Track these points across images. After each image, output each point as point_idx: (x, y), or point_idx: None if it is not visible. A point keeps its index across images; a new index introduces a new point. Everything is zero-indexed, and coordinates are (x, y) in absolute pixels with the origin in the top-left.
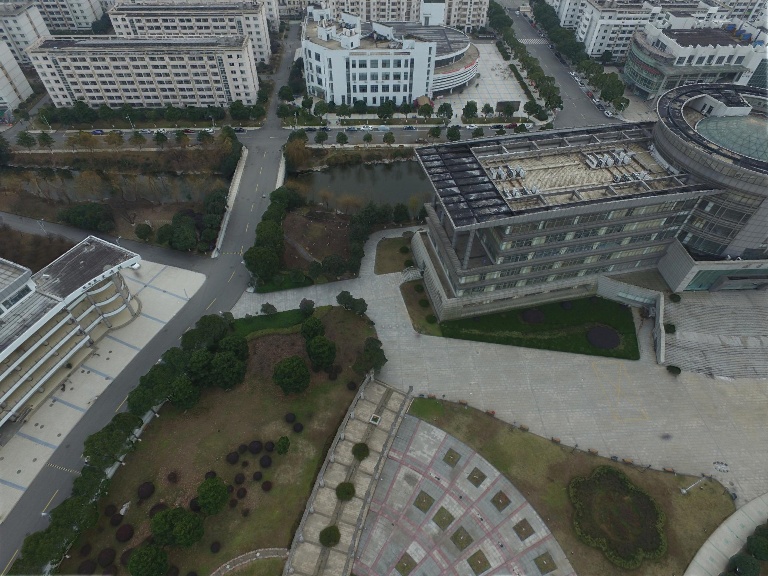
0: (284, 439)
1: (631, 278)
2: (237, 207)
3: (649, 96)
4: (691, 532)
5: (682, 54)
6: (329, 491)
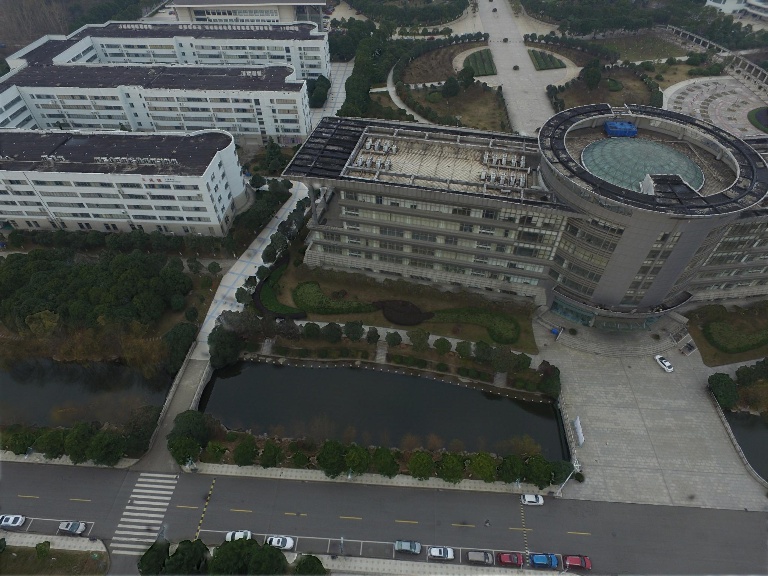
0: None
1: None
2: None
3: None
4: None
5: None
6: None
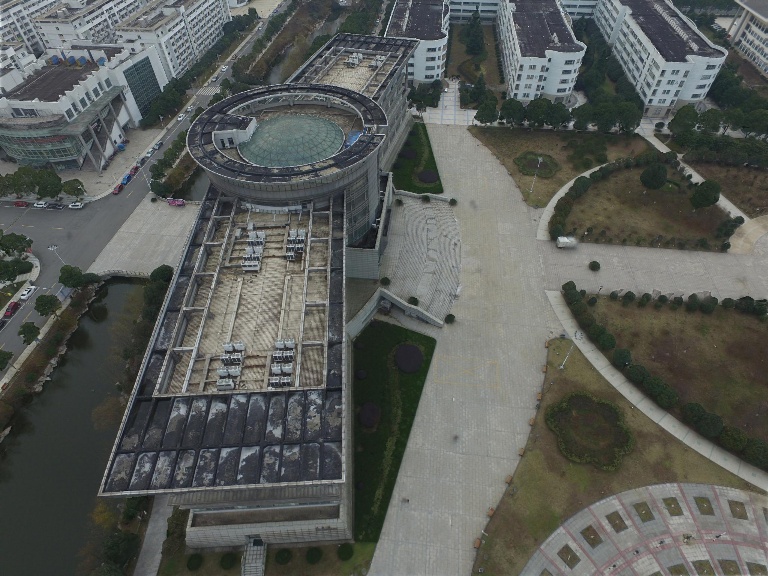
0: None
1: (352, 303)
2: None
3: (78, 162)
4: (595, 379)
5: (64, 108)
6: None
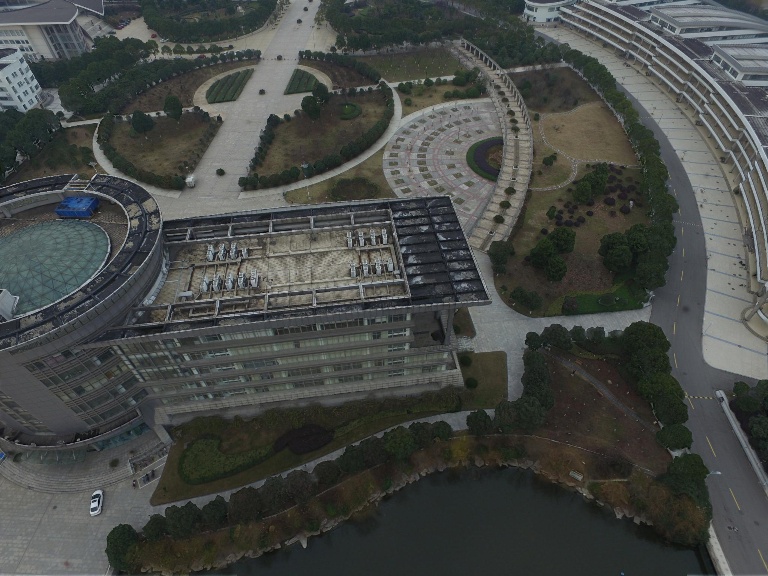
0: (551, 212)
1: None
2: (762, 501)
3: None
4: (319, 186)
5: None
6: (515, 206)
